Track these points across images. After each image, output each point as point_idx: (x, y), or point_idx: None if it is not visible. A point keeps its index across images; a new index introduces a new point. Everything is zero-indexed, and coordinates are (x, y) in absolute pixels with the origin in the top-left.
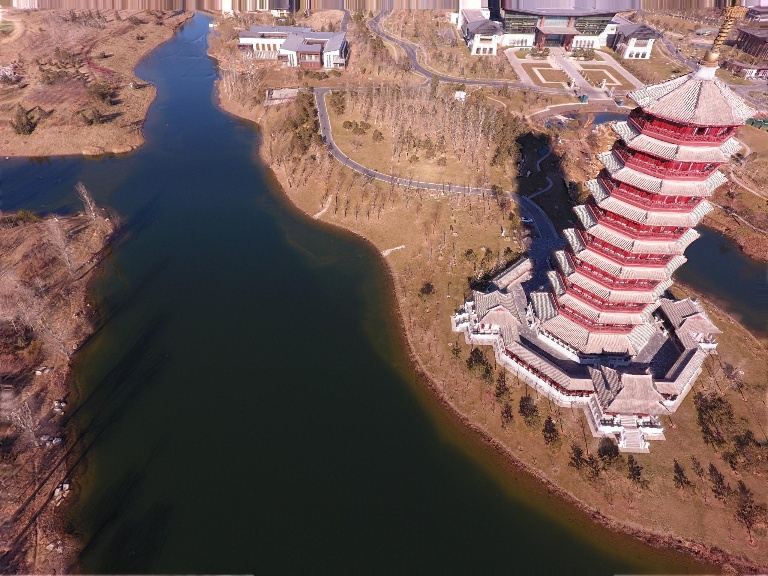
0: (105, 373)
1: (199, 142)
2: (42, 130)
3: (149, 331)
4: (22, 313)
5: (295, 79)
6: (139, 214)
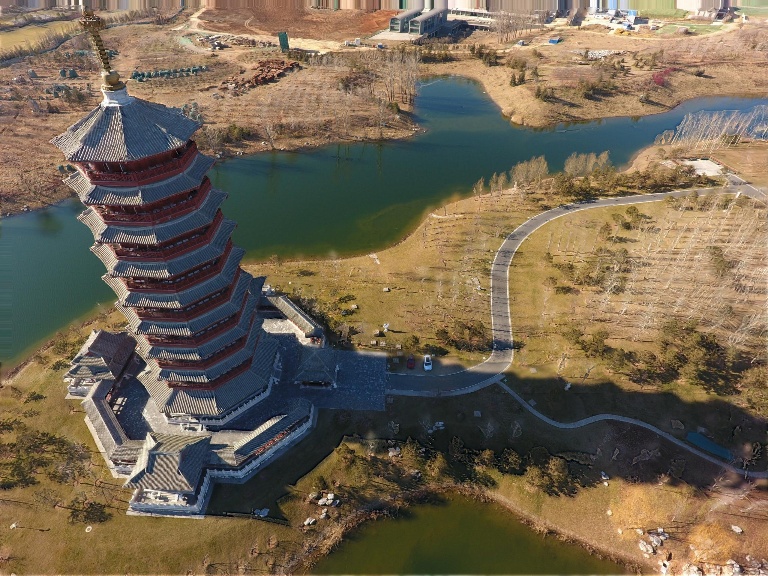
0: (259, 160)
1: (559, 149)
2: (520, 88)
3: (290, 166)
4: (295, 123)
5: (763, 169)
6: (421, 143)
